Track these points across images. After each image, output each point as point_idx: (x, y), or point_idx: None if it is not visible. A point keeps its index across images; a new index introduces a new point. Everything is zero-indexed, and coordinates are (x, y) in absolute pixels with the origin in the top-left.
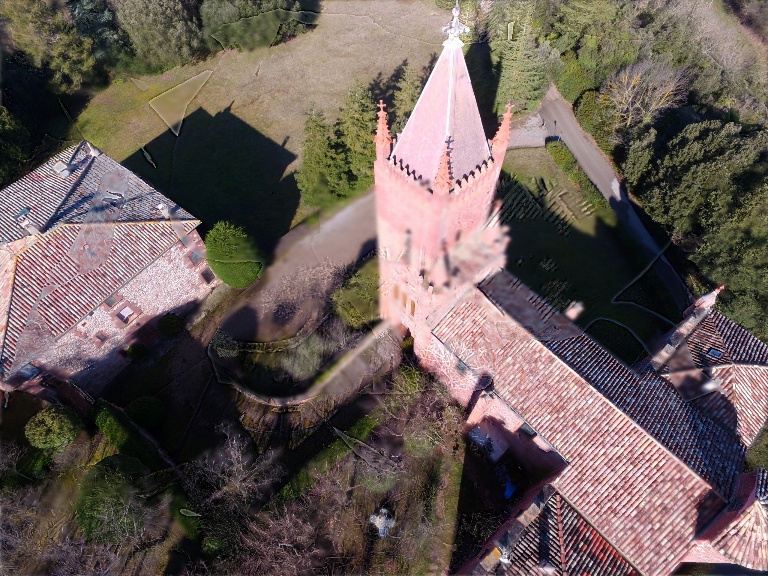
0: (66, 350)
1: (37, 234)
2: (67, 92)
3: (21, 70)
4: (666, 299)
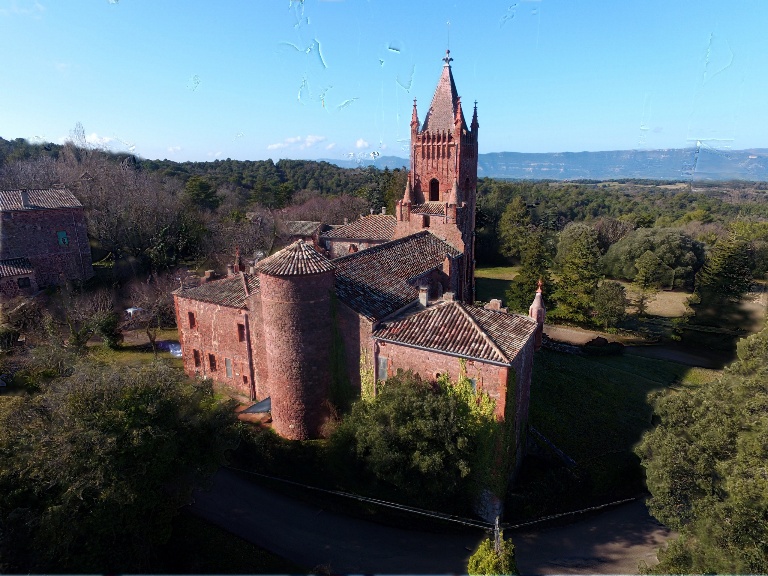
0: (342, 251)
1: (383, 214)
2: (504, 254)
3: (494, 235)
4: (627, 454)
